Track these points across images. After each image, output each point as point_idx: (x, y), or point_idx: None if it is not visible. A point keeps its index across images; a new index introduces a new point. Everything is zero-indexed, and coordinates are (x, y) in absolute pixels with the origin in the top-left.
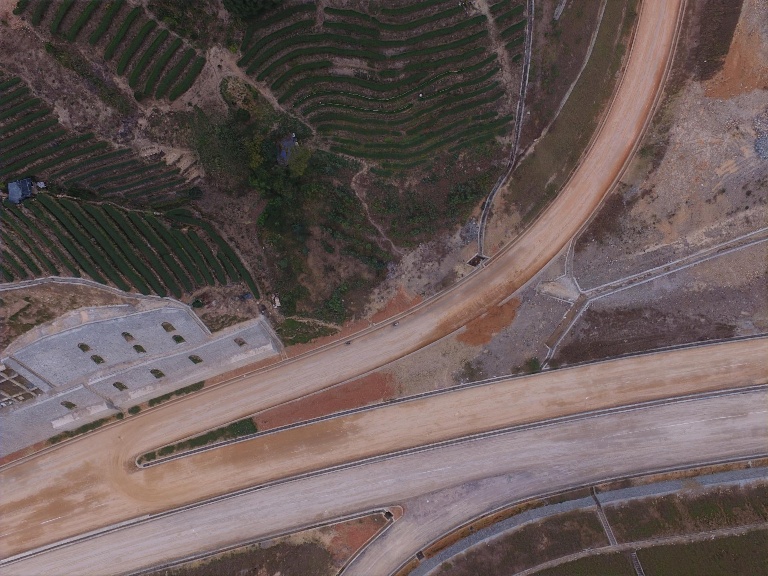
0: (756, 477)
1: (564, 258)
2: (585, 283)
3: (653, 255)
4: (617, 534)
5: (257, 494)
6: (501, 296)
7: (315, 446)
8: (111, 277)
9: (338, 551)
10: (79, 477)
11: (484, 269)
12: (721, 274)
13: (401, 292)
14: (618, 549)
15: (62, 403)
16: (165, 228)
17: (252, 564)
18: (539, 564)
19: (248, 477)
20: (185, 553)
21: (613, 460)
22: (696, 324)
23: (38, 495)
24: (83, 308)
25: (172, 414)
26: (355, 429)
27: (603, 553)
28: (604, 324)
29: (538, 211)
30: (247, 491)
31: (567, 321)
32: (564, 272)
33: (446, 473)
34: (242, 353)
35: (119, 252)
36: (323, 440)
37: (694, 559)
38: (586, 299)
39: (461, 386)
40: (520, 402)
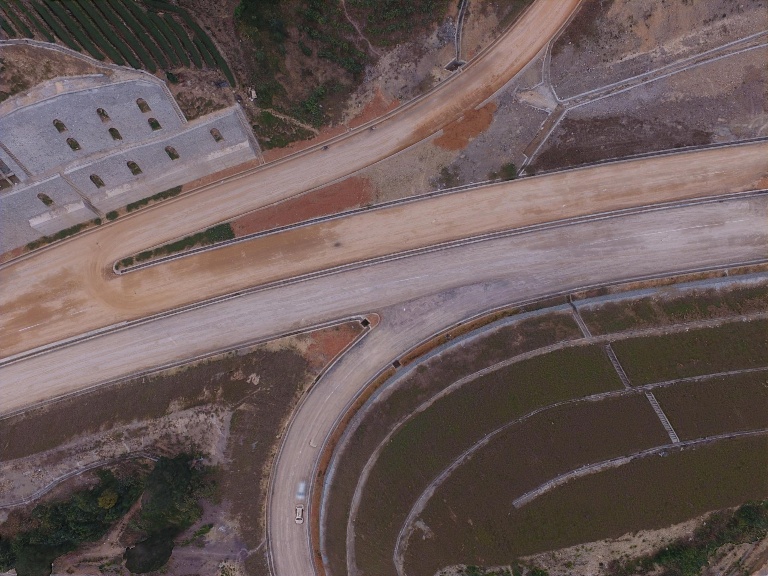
0: (732, 280)
1: (541, 63)
2: (562, 91)
3: (630, 63)
4: (592, 329)
5: (234, 302)
6: (478, 100)
7: (292, 253)
8: (86, 45)
9: (314, 358)
10: (57, 283)
11: (461, 74)
12: (698, 84)
13: (378, 95)
14: (592, 341)
15: (39, 197)
16: (141, 11)
17: (228, 368)
18: (513, 356)
19: (225, 284)
20: (162, 362)
21: (590, 269)
22: (673, 131)
23: (16, 301)
24: (58, 78)
25: (150, 220)
26: (332, 236)
27: (577, 345)
28: (581, 130)
29: (515, 15)
30: (224, 298)
31: (544, 131)
32: (541, 79)
33: (423, 281)
34: (219, 151)
35: (94, 25)
36: (300, 247)
37: (667, 346)
38: (564, 109)
39: (438, 193)
40: (497, 210)
